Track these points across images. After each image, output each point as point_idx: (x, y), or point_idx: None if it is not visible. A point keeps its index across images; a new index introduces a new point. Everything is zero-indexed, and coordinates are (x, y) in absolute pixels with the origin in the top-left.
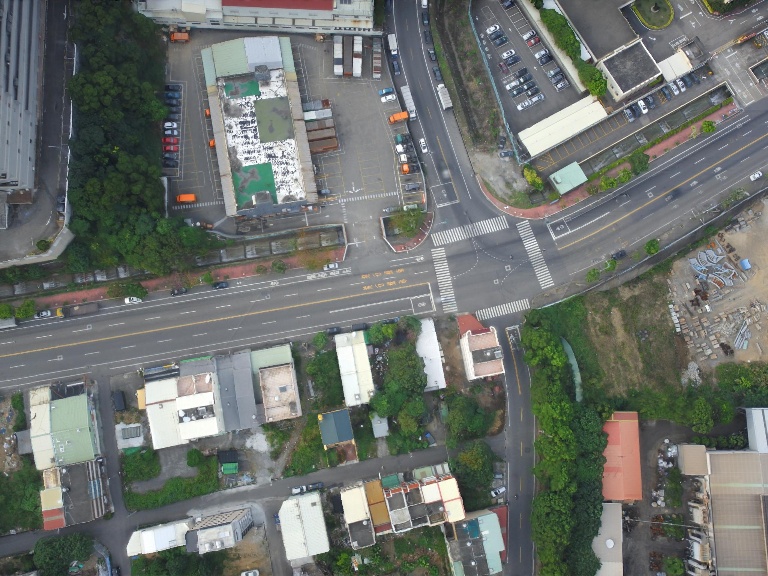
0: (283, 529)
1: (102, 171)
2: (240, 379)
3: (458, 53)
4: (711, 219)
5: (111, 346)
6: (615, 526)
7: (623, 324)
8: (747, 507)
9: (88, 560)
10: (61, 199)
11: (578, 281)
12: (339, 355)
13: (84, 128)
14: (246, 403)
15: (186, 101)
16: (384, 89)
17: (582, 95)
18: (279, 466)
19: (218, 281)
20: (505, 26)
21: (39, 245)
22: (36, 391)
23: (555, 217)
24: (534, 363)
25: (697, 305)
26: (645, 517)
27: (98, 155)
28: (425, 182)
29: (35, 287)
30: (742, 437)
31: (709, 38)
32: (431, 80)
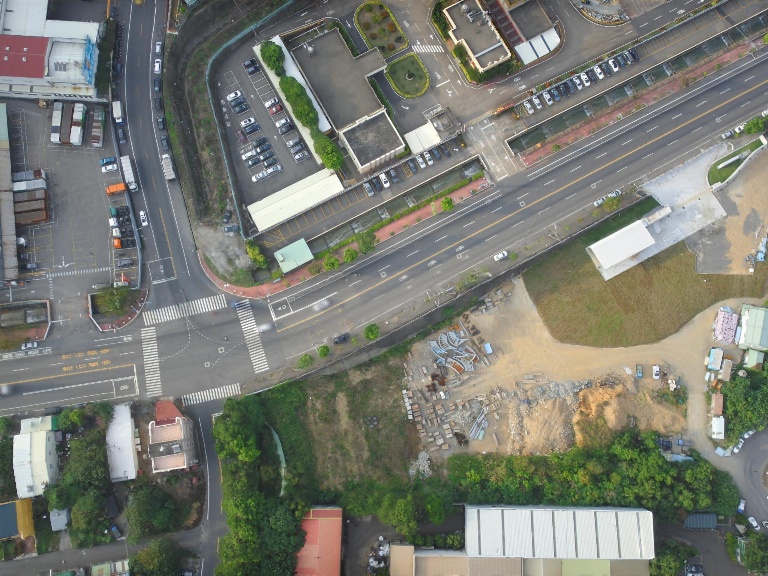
0: None
1: None
2: None
3: (194, 120)
4: (447, 301)
5: None
6: None
7: (348, 410)
8: None
9: None
10: None
11: (295, 366)
12: (15, 443)
13: None
14: None
15: None
16: (105, 159)
17: (322, 167)
18: None
19: None
20: (248, 92)
21: None
22: None
23: (278, 296)
24: (221, 457)
25: (433, 391)
26: None
27: None
28: (142, 257)
29: None
30: (458, 537)
31: (465, 108)
32: (159, 149)
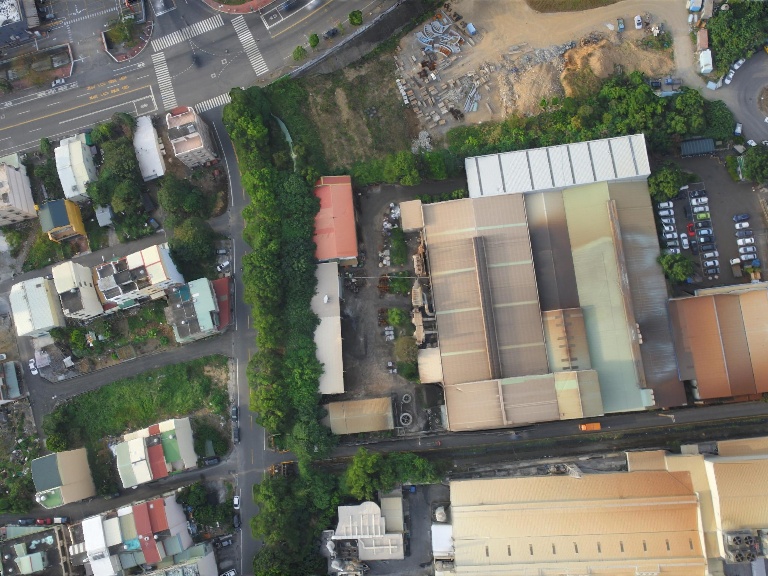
0: (13, 310)
1: None
2: None
3: None
4: None
5: None
6: (332, 283)
7: (347, 102)
8: (462, 251)
9: None
10: None
11: (292, 64)
12: (57, 154)
13: None
14: None
15: None
16: None
17: None
18: (19, 263)
19: None
20: None
21: None
22: None
23: (268, 8)
24: (233, 136)
25: (425, 76)
26: (373, 278)
27: None
28: None
29: None
30: (462, 189)
31: None
32: None
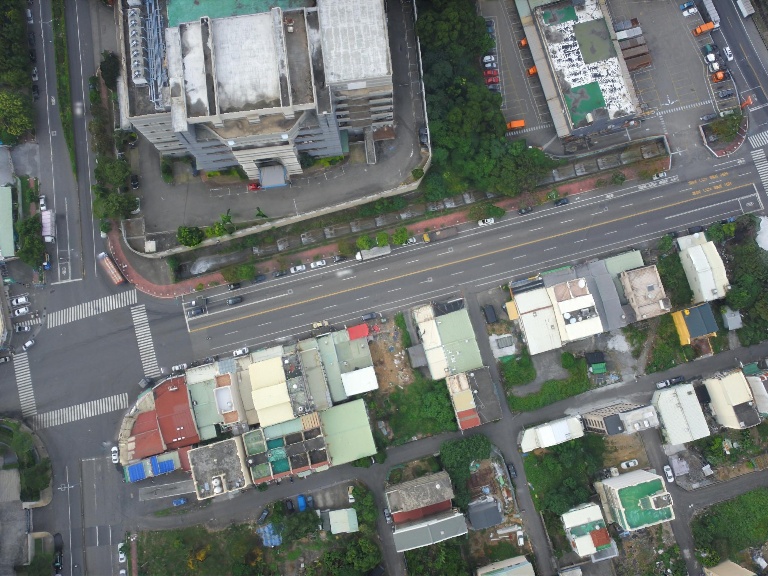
0: (664, 418)
1: (452, 103)
2: (603, 284)
3: None
4: None
5: (473, 265)
6: None
7: None
8: None
9: (483, 460)
10: (424, 131)
11: None
12: (691, 255)
13: (435, 64)
14: (613, 305)
15: (499, 35)
16: (685, 3)
17: None
18: (641, 364)
19: (558, 198)
20: None
21: (416, 173)
22: (419, 310)
23: None
24: None
25: None
26: None
27: (451, 87)
28: (735, 88)
29: (394, 218)
30: None
31: None
32: None
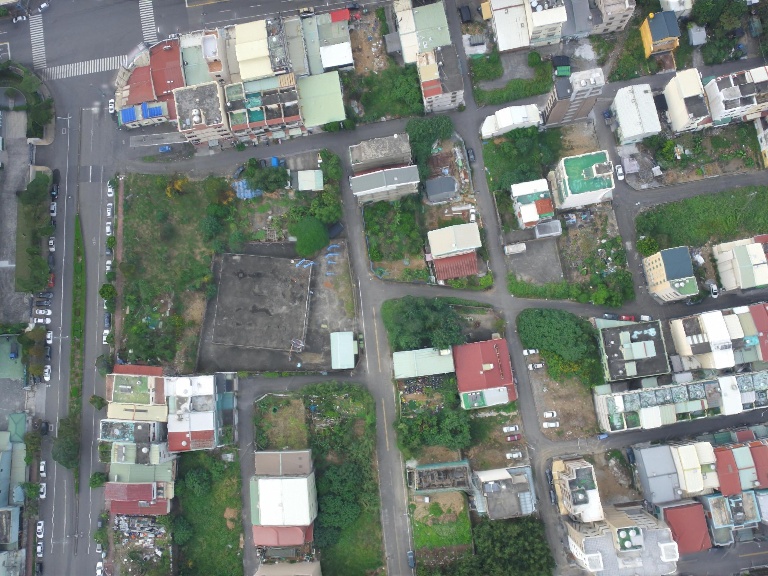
0: (619, 112)
1: None
2: None
3: None
4: None
5: None
6: None
7: None
8: None
9: (446, 144)
10: None
11: None
12: None
13: None
14: (582, 8)
15: None
16: None
17: None
18: (605, 72)
19: None
20: None
21: None
22: (399, 1)
23: None
24: None
25: None
26: None
27: None
28: None
29: None
30: None
31: None
32: None
